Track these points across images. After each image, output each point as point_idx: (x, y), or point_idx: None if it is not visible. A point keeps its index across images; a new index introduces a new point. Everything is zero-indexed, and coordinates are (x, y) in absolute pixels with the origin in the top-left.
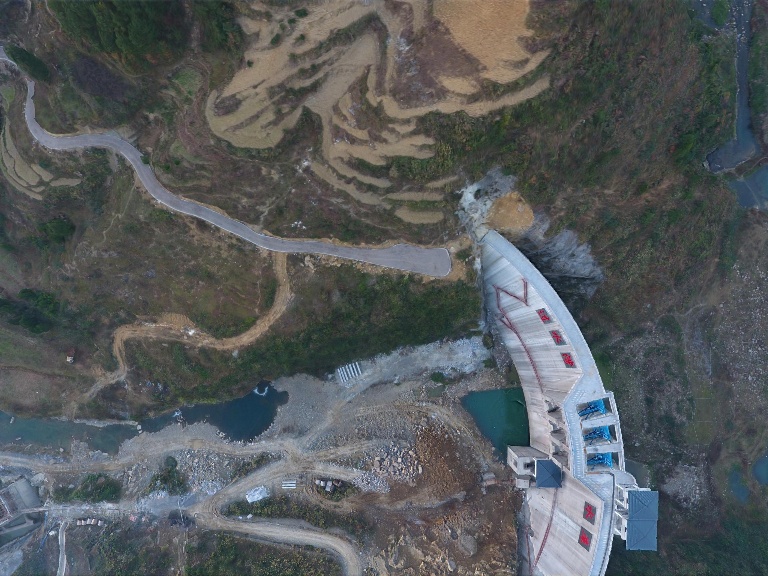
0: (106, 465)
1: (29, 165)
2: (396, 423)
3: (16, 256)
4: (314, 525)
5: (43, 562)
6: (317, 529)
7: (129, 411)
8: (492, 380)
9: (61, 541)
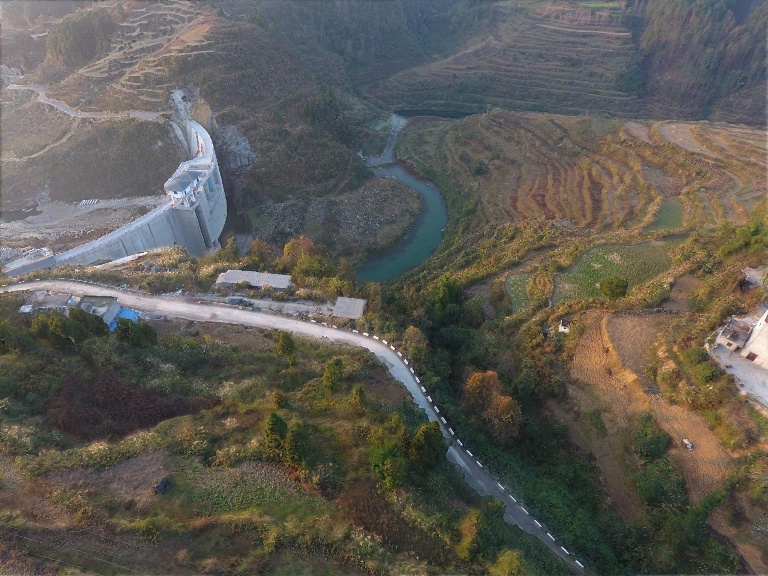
0: None
1: None
2: None
3: None
4: None
5: None
6: None
7: None
8: None
9: None
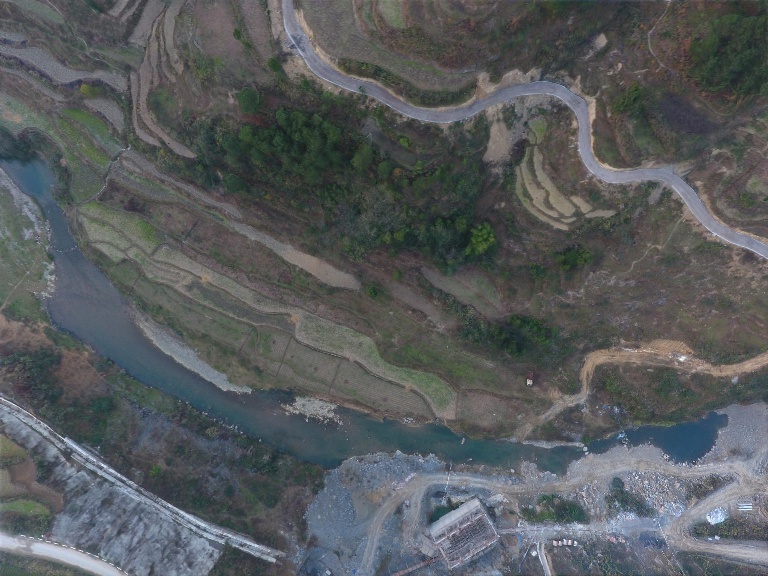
0: (557, 486)
1: (566, 197)
2: None
3: (497, 282)
4: None
5: None
6: None
7: (583, 433)
8: None
9: (542, 561)
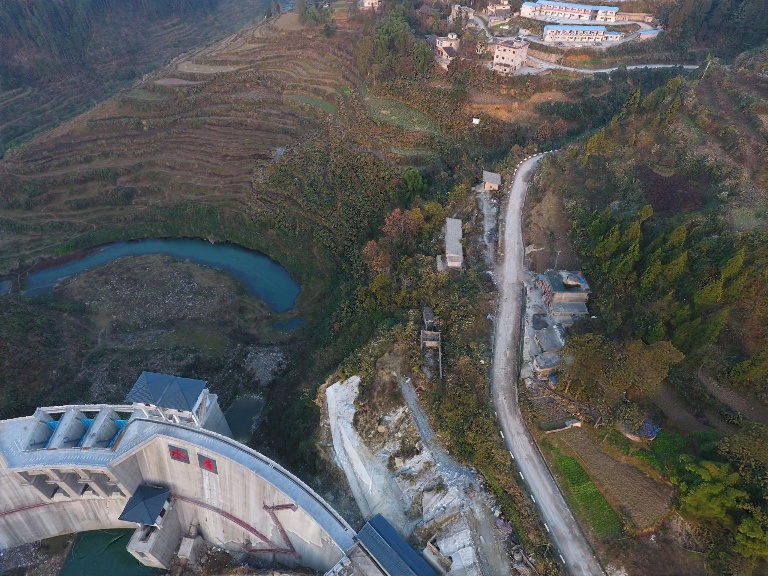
0: None
1: None
2: None
3: None
4: None
5: None
6: None
7: None
8: None
9: None
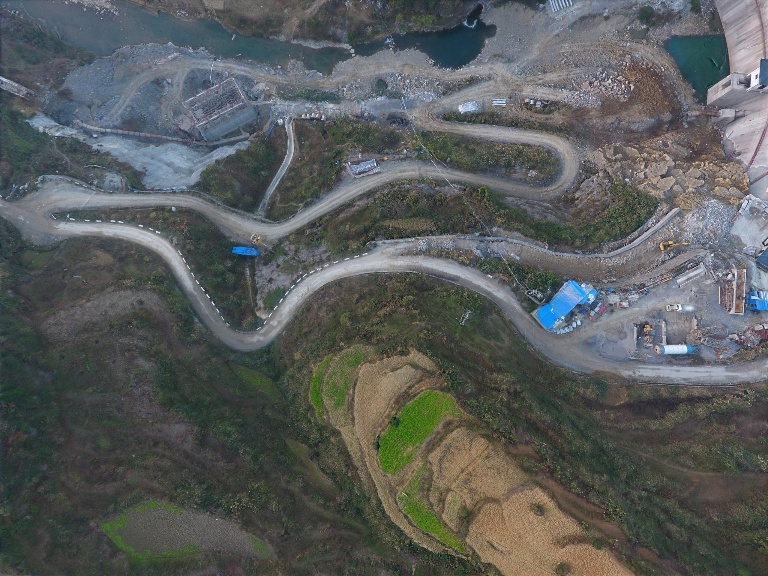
0: (321, 82)
1: None
2: (601, 58)
3: None
4: (529, 128)
5: (271, 146)
6: (533, 129)
7: (347, 29)
8: (696, 25)
9: (288, 130)
